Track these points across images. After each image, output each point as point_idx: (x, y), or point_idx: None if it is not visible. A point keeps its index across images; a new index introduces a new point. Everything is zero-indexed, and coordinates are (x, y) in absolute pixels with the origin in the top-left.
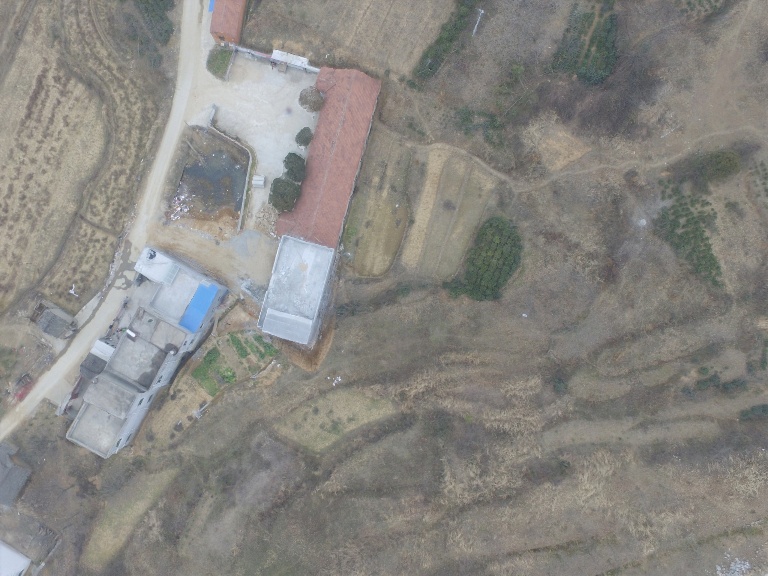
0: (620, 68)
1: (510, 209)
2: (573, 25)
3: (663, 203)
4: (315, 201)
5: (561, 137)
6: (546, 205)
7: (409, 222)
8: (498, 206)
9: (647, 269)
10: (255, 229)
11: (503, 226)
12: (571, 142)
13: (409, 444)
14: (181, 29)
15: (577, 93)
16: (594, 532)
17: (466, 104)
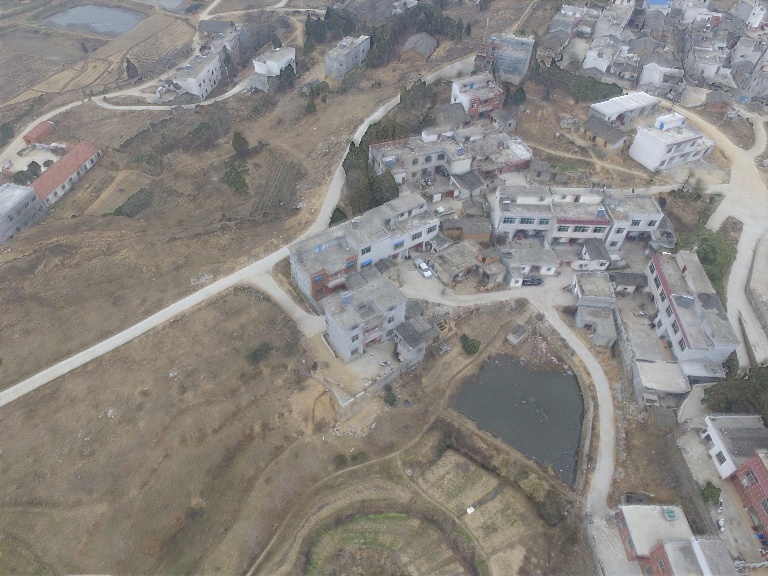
0: None
1: None
2: None
3: (226, 170)
4: (38, 180)
5: (183, 157)
6: (169, 180)
7: None
8: (149, 188)
9: (214, 195)
10: None
11: (144, 190)
12: (188, 158)
13: (29, 260)
14: (12, 143)
15: (191, 140)
16: (120, 276)
17: (142, 154)
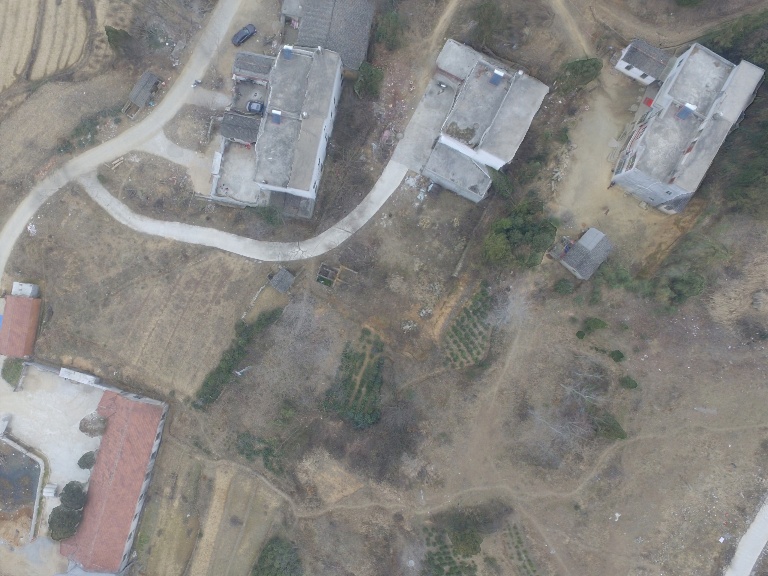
0: (384, 417)
1: (292, 532)
2: (345, 363)
3: (429, 548)
4: (94, 530)
5: (335, 472)
6: (322, 535)
7: (198, 534)
8: (283, 524)
9: None
10: (49, 536)
11: (283, 551)
12: (344, 477)
13: None
14: None
15: (344, 437)
16: None
17: (247, 429)
